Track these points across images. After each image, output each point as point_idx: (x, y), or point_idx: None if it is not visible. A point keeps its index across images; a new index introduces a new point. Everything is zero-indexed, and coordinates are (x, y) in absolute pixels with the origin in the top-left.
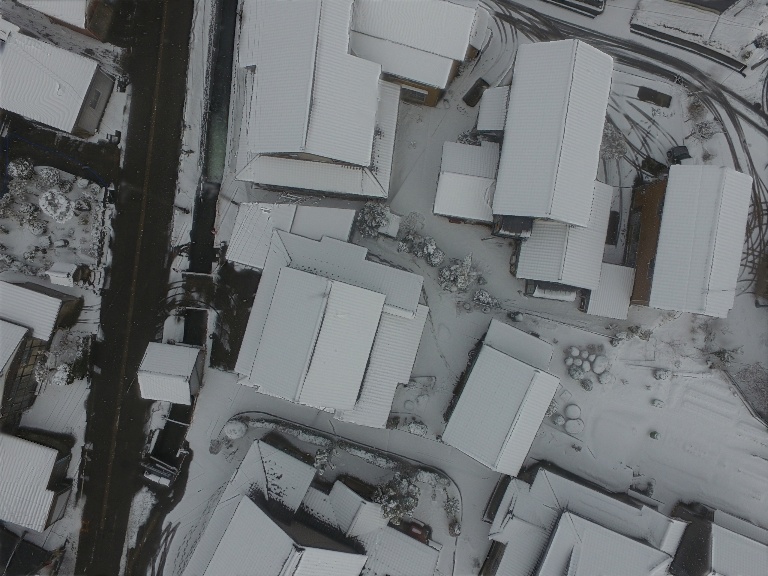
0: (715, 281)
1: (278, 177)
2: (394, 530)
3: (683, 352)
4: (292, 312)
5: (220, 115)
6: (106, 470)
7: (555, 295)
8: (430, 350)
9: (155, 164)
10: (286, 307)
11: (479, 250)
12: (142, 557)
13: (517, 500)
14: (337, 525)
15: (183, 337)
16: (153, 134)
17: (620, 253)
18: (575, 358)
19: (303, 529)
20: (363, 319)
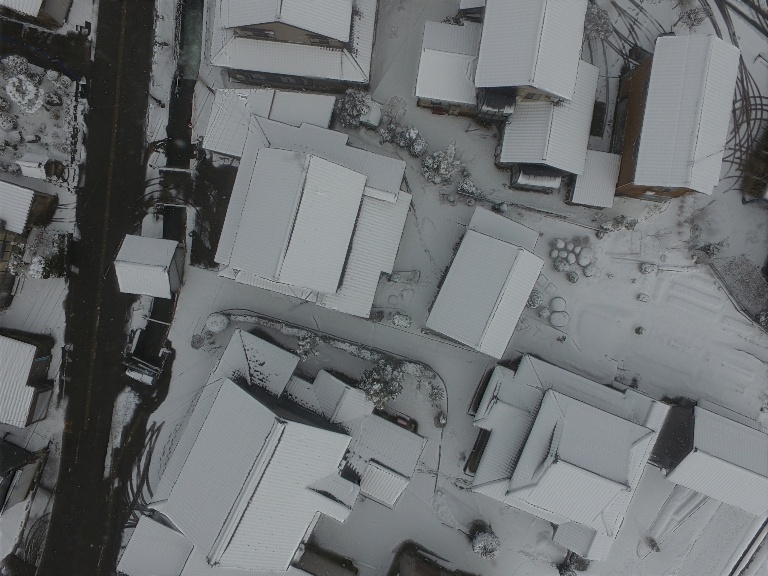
0: (700, 154)
1: (255, 61)
2: (379, 417)
3: (669, 245)
4: (271, 191)
5: (195, 7)
6: (87, 370)
7: (540, 181)
8: (414, 244)
9: (128, 56)
10: (264, 187)
11: (463, 142)
12: (127, 456)
13: (501, 385)
14: (321, 412)
15: (162, 236)
16: (125, 25)
17: (606, 144)
18: (560, 250)
19: (287, 413)
20: (344, 199)
